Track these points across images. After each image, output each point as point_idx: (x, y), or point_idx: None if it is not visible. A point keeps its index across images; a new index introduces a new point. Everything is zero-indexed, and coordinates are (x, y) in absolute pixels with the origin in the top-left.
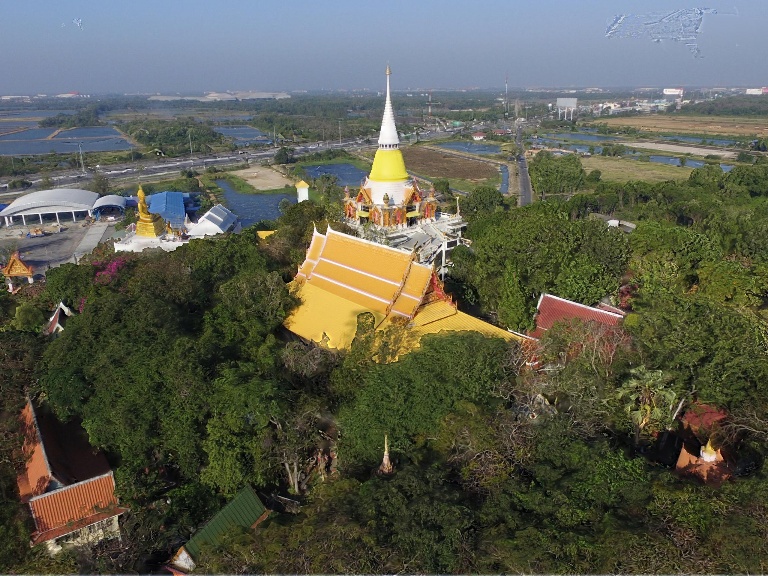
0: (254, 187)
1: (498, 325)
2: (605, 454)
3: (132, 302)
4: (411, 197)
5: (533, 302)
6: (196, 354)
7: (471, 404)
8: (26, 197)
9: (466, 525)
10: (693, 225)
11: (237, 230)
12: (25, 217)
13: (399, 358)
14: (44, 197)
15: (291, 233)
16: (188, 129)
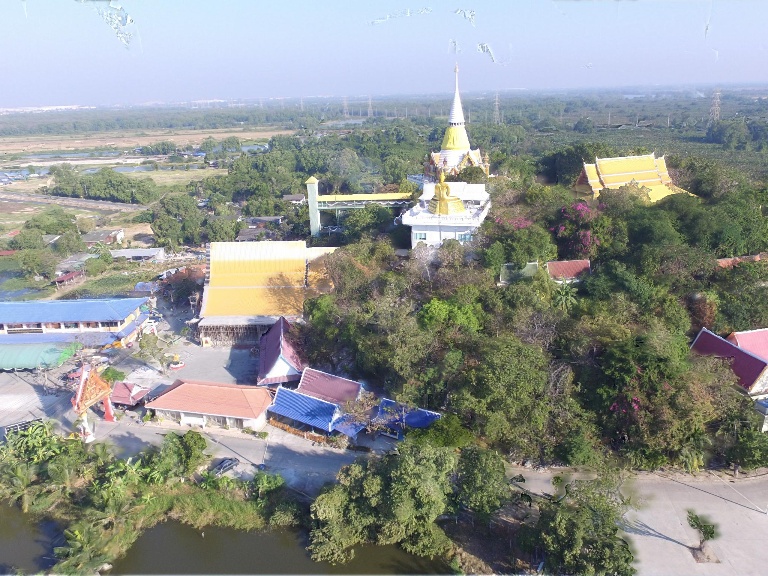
0: None
1: None
2: None
3: None
4: None
5: None
6: None
7: (757, 182)
8: None
9: None
10: (336, 190)
11: None
12: None
13: (706, 189)
14: None
15: None
16: None
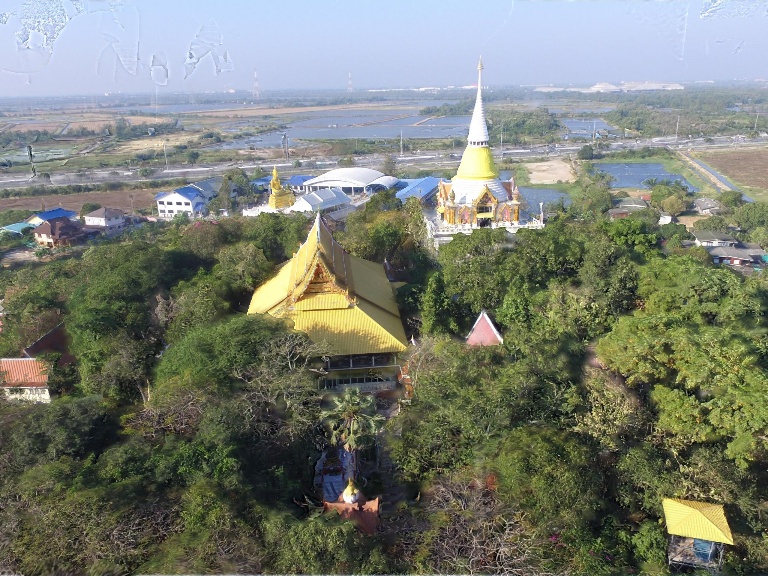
0: (529, 180)
1: (418, 333)
2: (218, 445)
3: (146, 249)
4: (485, 197)
5: (470, 319)
6: (120, 291)
7: (188, 372)
8: (329, 172)
9: (68, 450)
10: None
11: (345, 211)
12: (320, 188)
13: None
14: (338, 173)
15: (356, 218)
16: (527, 120)
